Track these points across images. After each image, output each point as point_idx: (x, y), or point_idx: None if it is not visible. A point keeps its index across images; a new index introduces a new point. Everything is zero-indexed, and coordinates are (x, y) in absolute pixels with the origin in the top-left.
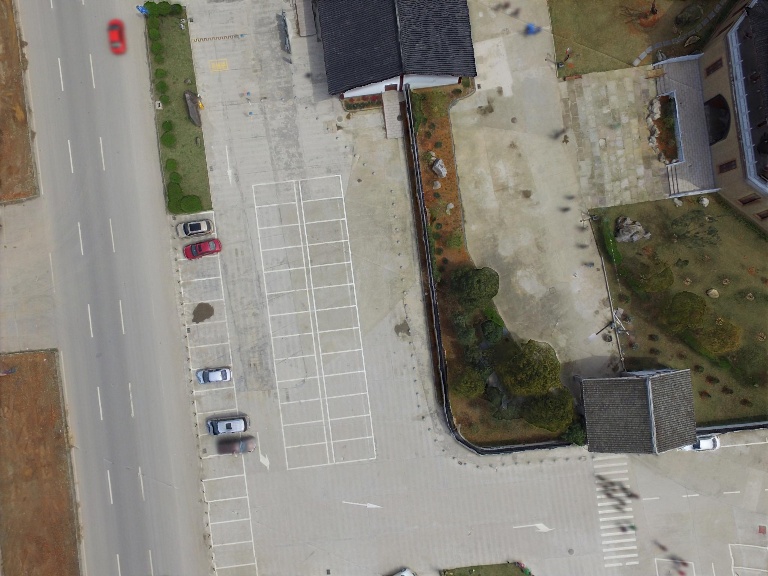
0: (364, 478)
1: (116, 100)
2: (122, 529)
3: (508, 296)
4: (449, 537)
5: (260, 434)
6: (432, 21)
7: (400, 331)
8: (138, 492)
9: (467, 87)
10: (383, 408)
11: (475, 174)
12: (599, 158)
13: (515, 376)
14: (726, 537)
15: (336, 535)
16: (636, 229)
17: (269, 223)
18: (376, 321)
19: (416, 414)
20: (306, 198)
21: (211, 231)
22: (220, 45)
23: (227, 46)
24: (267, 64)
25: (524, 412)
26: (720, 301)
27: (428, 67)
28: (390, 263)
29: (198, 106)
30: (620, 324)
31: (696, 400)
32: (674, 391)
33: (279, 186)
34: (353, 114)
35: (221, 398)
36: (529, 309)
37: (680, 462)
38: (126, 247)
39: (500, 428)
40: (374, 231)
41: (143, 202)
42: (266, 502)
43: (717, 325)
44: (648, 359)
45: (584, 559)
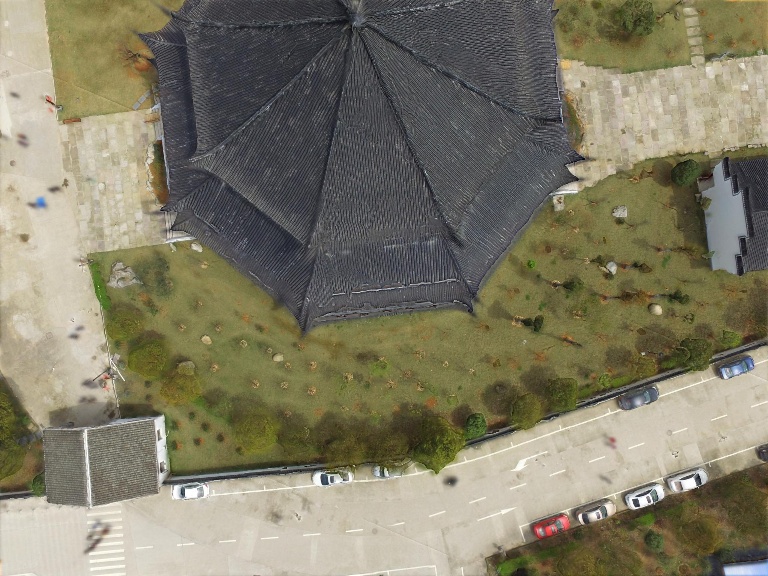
0: None
1: None
2: None
3: (4, 341)
4: None
5: None
6: None
7: None
8: None
9: None
10: None
11: None
12: (98, 202)
13: None
14: None
15: None
16: (120, 275)
17: None
18: None
19: None
20: None
21: None
22: None
23: None
24: None
25: None
26: (216, 347)
27: None
28: None
29: None
30: (116, 370)
31: (190, 448)
32: (126, 442)
33: None
34: None
35: None
36: (25, 354)
37: (175, 510)
38: None
39: None
40: None
41: None
42: None
43: (211, 372)
44: (143, 406)
45: None
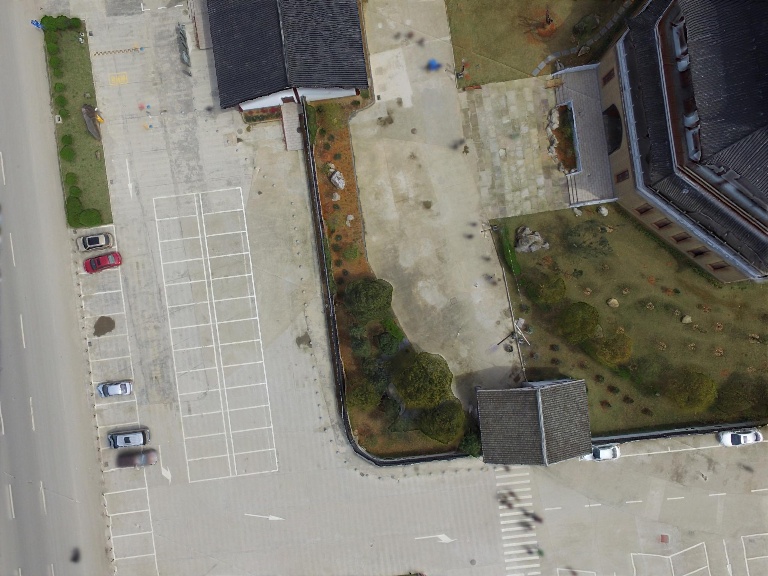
0: (266, 490)
1: (16, 114)
2: (24, 543)
3: (409, 307)
4: (351, 549)
5: (162, 447)
6: (320, 34)
7: (301, 343)
8: (40, 506)
9: (366, 98)
10: (285, 420)
11: (375, 185)
12: (499, 168)
13: (405, 388)
14: (628, 546)
15: (238, 547)
16: (534, 239)
17: (170, 236)
18: (277, 333)
19: (318, 426)
20: (207, 211)
21: (110, 245)
22: (120, 58)
23: (127, 59)
24: (167, 77)
25: (417, 424)
26: (621, 310)
27: (316, 80)
28: (291, 275)
29: (96, 120)
30: (521, 334)
31: (597, 410)
32: (567, 402)
33: (180, 199)
34: (253, 126)
35: (123, 411)
36: (430, 320)
37: (582, 472)
38: (26, 261)
39: (401, 439)
40: (275, 243)
41: (43, 216)
42: (168, 515)
43: None
44: (549, 369)
45: (486, 570)
